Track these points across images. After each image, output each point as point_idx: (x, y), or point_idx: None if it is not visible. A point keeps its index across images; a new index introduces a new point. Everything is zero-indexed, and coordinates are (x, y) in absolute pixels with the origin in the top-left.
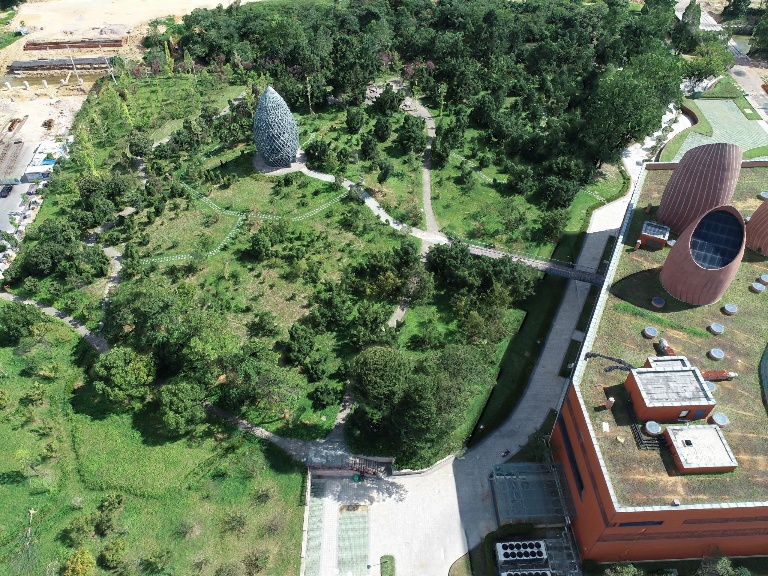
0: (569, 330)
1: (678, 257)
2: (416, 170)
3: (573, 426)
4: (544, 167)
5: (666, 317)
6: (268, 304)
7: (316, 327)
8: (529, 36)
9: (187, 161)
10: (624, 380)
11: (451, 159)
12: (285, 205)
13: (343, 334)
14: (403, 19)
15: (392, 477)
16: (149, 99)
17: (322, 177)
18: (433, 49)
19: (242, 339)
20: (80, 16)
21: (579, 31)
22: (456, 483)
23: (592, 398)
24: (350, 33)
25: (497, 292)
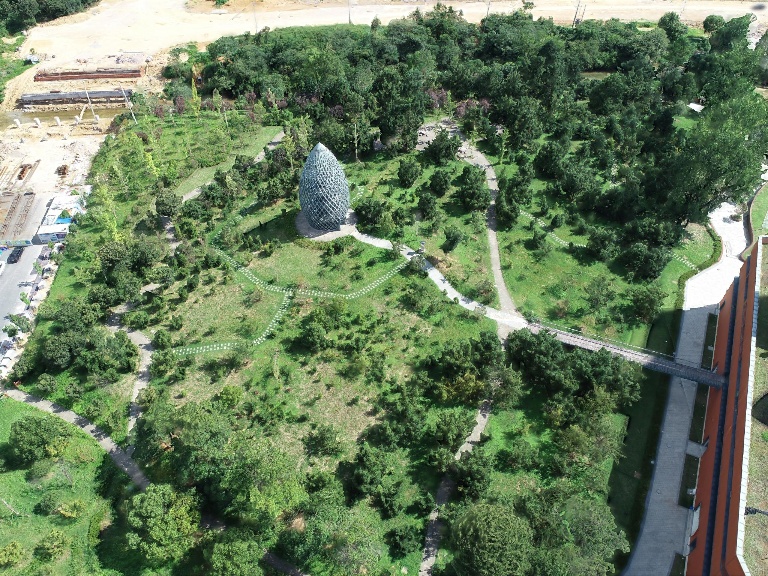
0: (682, 441)
1: None
2: (481, 232)
3: None
4: (627, 229)
5: None
6: (326, 410)
7: (387, 445)
8: (581, 65)
9: (220, 220)
10: None
11: (518, 217)
12: (336, 278)
13: (418, 450)
14: (446, 48)
15: None
16: (175, 144)
17: (376, 242)
18: (488, 86)
19: (299, 459)
20: (94, 42)
21: (643, 63)
22: None
23: None
24: (389, 63)
25: (600, 399)
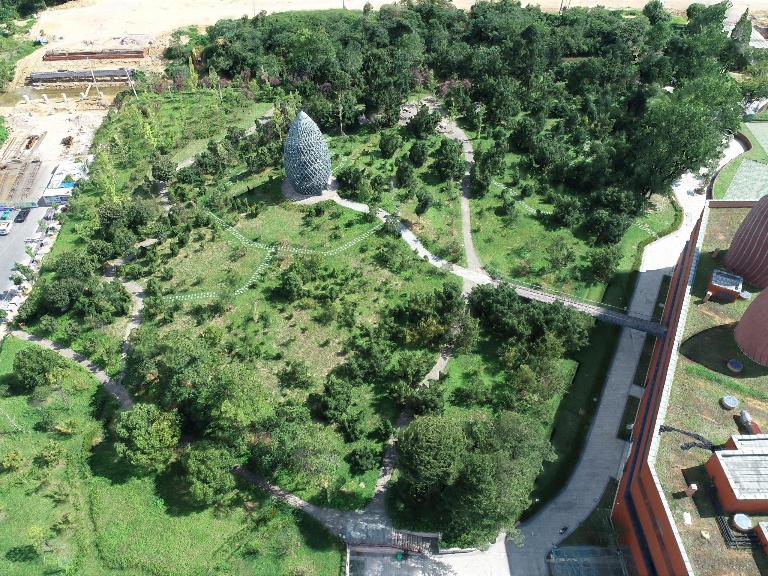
0: (626, 384)
1: (760, 317)
2: (454, 199)
3: (647, 512)
4: (591, 198)
5: (745, 384)
6: (300, 350)
7: (353, 379)
8: (566, 50)
9: (212, 186)
10: (704, 460)
11: (491, 187)
12: (316, 237)
13: (381, 386)
14: (435, 32)
15: (438, 556)
16: (172, 117)
17: (355, 206)
18: (469, 67)
19: (273, 391)
20: (101, 25)
21: (622, 47)
22: (510, 565)
23: (669, 482)
24: (380, 46)
25: (549, 343)
